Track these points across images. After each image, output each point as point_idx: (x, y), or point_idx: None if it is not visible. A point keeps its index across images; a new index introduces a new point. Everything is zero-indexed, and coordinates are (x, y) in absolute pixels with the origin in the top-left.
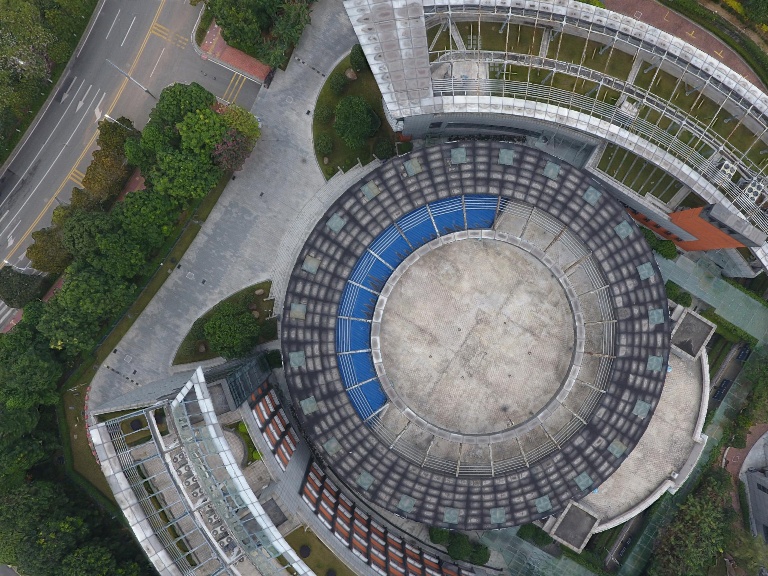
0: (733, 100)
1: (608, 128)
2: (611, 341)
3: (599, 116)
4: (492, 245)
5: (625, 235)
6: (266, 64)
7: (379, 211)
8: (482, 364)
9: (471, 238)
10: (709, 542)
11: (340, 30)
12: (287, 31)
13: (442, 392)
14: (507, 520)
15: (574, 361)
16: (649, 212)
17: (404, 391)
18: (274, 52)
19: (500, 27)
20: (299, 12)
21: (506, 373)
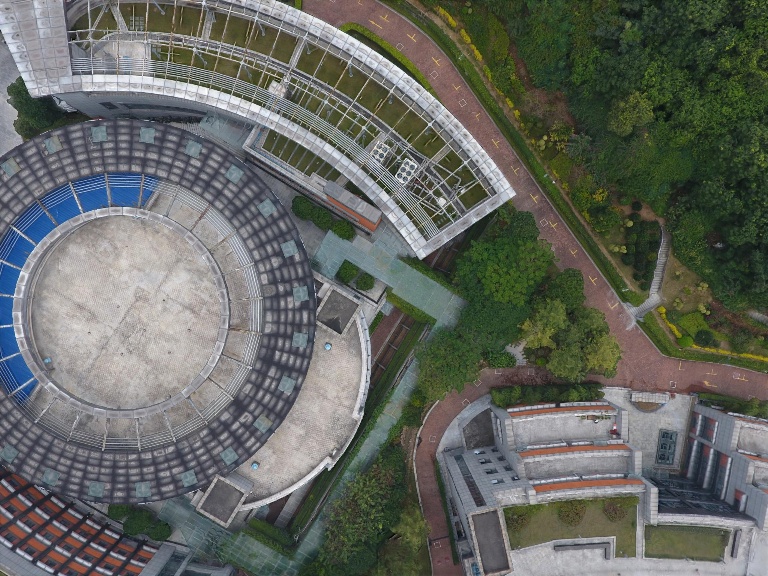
0: (375, 80)
1: (249, 107)
2: (258, 318)
3: (240, 95)
4: (150, 223)
5: (269, 213)
6: None
7: (21, 188)
8: (142, 341)
9: (112, 215)
10: (368, 518)
11: None
12: None
13: (102, 368)
14: (153, 494)
15: (218, 337)
16: (313, 192)
17: (63, 367)
18: None
19: (162, 8)
20: None
21: (166, 350)
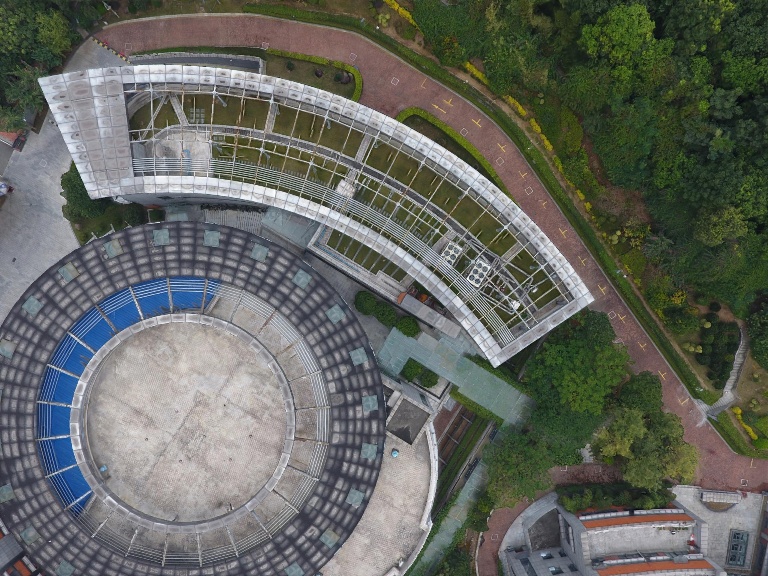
0: (449, 181)
1: (318, 210)
2: (325, 427)
3: (309, 197)
4: None
5: (337, 319)
6: (3, 131)
7: (79, 293)
8: (201, 447)
9: None
10: None
11: None
12: (20, 98)
13: (159, 476)
14: None
15: (284, 449)
16: None
17: (119, 475)
18: (7, 120)
19: (224, 100)
20: (33, 79)
21: (226, 456)
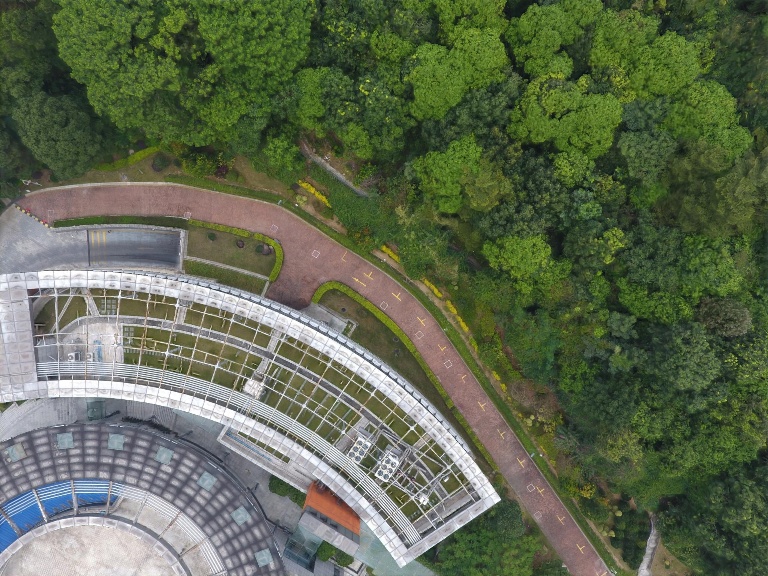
0: (356, 383)
1: (223, 412)
2: None
3: (214, 400)
4: None
5: (243, 520)
6: None
7: None
8: None
9: (78, 525)
10: None
11: (17, 259)
12: None
13: None
14: None
15: None
16: None
17: None
18: None
19: None
20: None
21: None
